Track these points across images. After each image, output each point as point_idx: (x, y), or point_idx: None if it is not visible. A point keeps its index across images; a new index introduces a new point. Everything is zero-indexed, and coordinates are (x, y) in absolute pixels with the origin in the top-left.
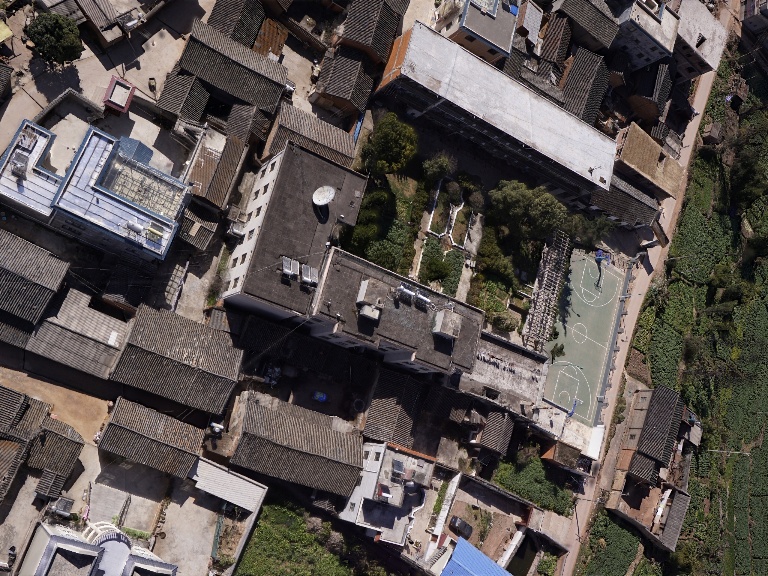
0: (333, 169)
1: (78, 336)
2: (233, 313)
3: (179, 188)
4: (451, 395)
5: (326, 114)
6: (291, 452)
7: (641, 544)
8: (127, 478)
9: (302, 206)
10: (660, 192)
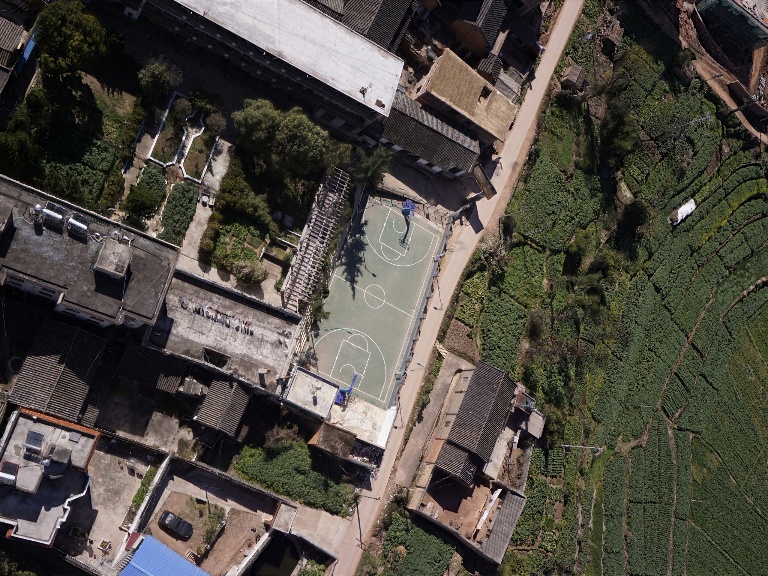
0: None
1: None
2: None
3: None
4: (157, 357)
5: (7, 7)
6: None
7: (458, 554)
8: None
9: None
10: (484, 133)
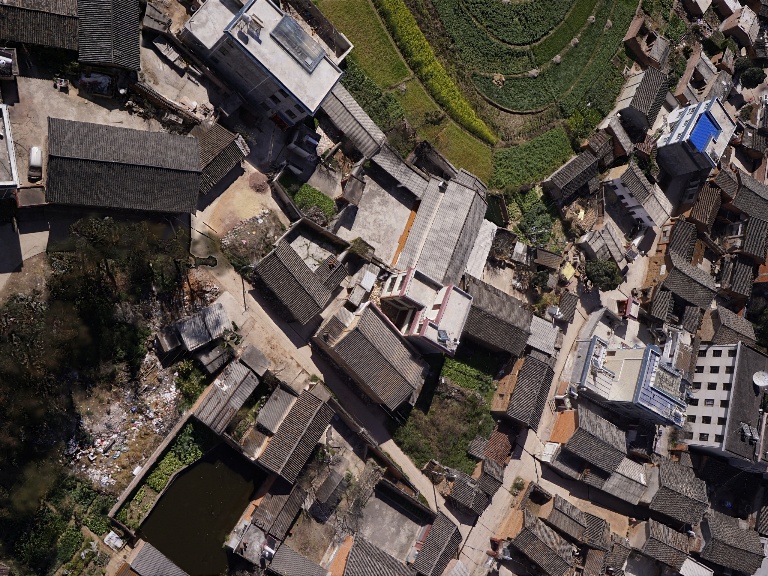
0: (761, 357)
1: (628, 479)
2: (693, 454)
3: (676, 376)
4: None
5: (720, 300)
6: (731, 548)
7: None
8: (638, 567)
9: (748, 386)
10: None
